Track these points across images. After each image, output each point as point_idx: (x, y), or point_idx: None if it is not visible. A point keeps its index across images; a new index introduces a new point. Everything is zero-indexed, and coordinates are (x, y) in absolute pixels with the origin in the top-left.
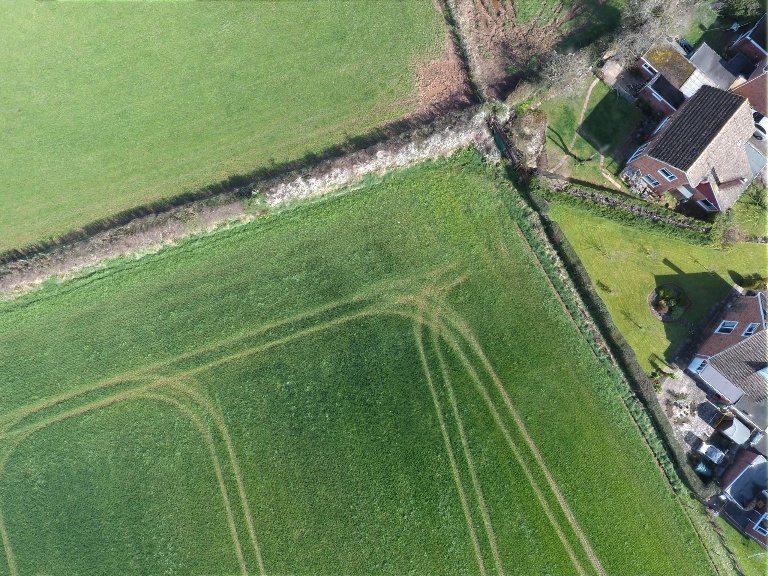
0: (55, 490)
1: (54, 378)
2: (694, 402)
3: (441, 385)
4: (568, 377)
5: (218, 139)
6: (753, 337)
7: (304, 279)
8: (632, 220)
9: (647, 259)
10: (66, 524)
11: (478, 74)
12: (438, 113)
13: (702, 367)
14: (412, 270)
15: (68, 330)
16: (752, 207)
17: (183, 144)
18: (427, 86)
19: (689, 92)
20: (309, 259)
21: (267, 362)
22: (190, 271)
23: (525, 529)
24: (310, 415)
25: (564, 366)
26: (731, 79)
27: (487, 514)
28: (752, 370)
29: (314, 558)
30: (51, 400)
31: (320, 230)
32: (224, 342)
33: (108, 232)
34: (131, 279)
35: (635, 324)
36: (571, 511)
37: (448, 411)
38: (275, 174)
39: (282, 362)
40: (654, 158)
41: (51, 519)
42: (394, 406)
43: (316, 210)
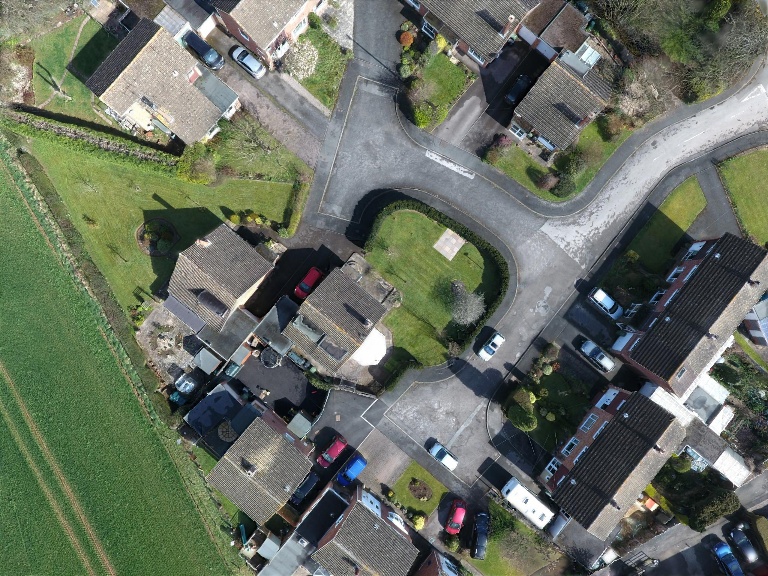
0: None
1: None
2: (180, 335)
3: None
4: (47, 309)
5: None
6: (177, 263)
7: None
8: (92, 152)
9: (136, 194)
10: None
11: None
12: None
13: None
14: None
15: None
16: (247, 144)
17: None
18: None
19: None
20: None
21: None
22: None
23: None
24: None
25: (43, 298)
26: (204, 16)
27: None
28: None
29: None
30: None
31: None
32: None
33: None
34: None
35: (120, 257)
36: (43, 440)
37: None
38: None
39: None
40: None
41: None
42: None
43: None
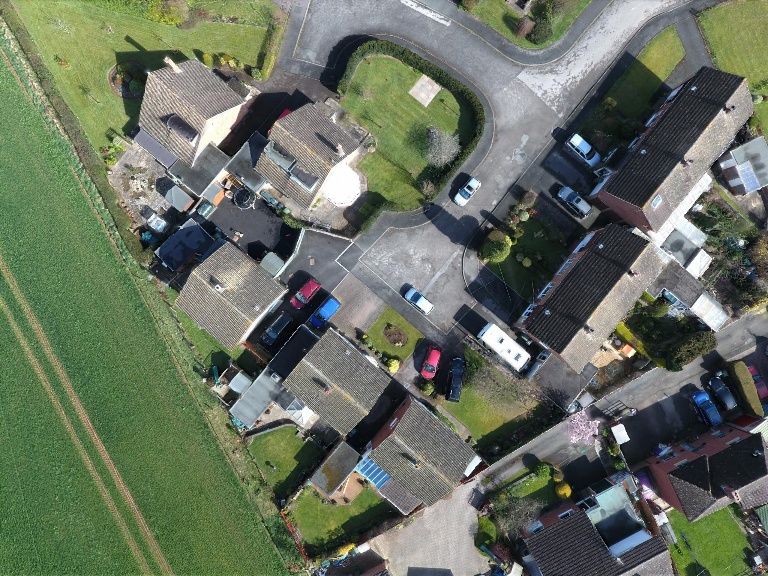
0: None
1: None
2: (152, 177)
3: None
4: (18, 148)
5: None
6: (147, 85)
7: None
8: None
9: (109, 36)
10: None
11: None
12: None
13: None
14: None
15: None
16: None
17: None
18: None
19: None
20: None
21: None
22: None
23: None
24: None
25: (15, 137)
26: None
27: None
28: None
29: None
30: None
31: None
32: None
33: None
34: None
35: (92, 99)
36: (14, 278)
37: None
38: None
39: None
40: None
41: None
42: None
43: None
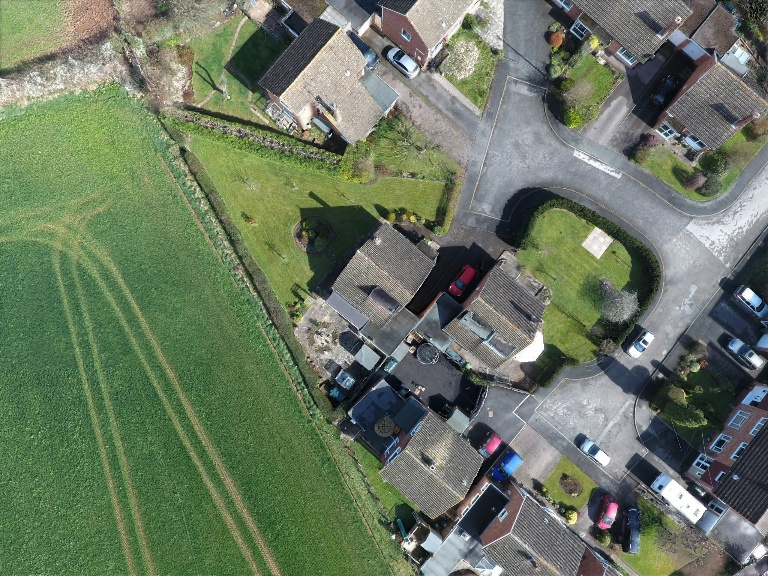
0: None
1: None
2: (336, 331)
3: (76, 310)
4: (208, 305)
5: None
6: (352, 260)
7: None
8: (258, 150)
9: (293, 192)
10: None
11: (127, 11)
12: None
13: None
14: (51, 198)
15: None
16: (400, 143)
17: None
18: (77, 22)
19: None
20: None
21: None
22: None
23: (156, 450)
24: None
25: (204, 294)
26: (365, 16)
27: (118, 435)
28: (365, 295)
29: None
30: None
31: None
32: None
33: None
34: None
35: (278, 255)
36: (205, 434)
37: (81, 335)
38: None
39: None
40: None
41: None
42: (26, 329)
43: None
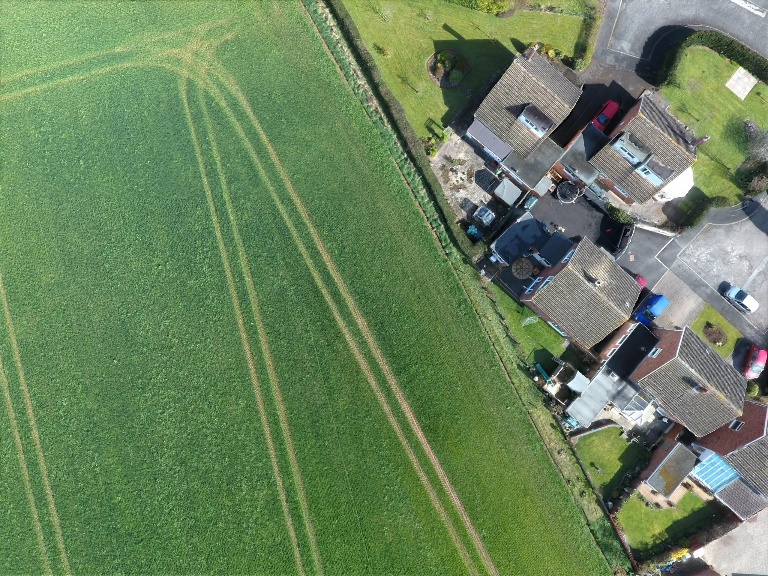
0: None
1: None
2: (471, 169)
3: (204, 138)
4: (339, 138)
5: None
6: (505, 74)
7: (64, 27)
8: None
9: (426, 24)
10: None
11: None
12: None
13: None
14: (177, 22)
15: None
16: None
17: None
18: None
19: None
20: (70, 7)
21: (22, 108)
22: None
23: (287, 286)
24: (64, 161)
25: (335, 126)
26: None
27: (248, 270)
28: (513, 118)
29: (62, 304)
30: None
31: None
32: None
33: None
34: None
35: (411, 88)
36: (338, 271)
37: (210, 164)
38: None
39: (37, 108)
40: None
41: None
42: (153, 156)
43: None
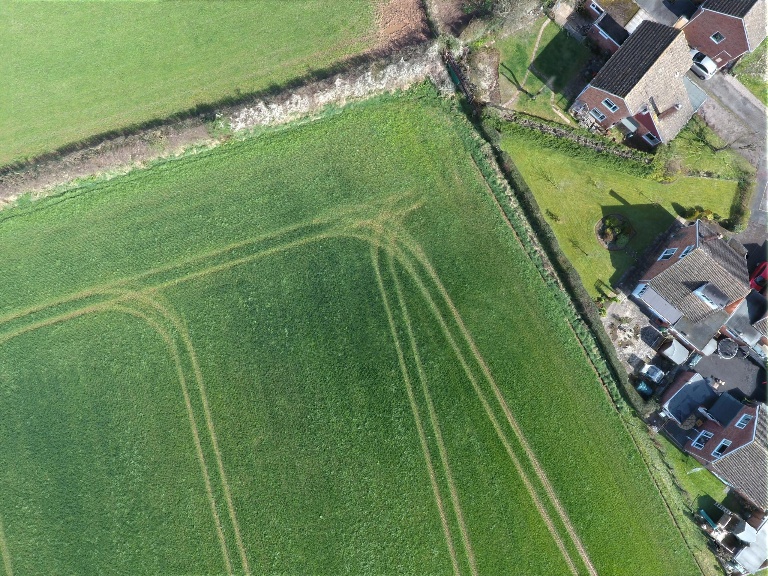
0: (26, 395)
1: (27, 290)
2: (637, 326)
3: (396, 304)
4: (517, 300)
5: (187, 69)
6: (687, 256)
7: (267, 202)
8: (577, 149)
9: (594, 190)
10: (36, 426)
11: (435, 13)
12: (397, 49)
13: (643, 290)
14: (370, 196)
15: (41, 245)
16: (695, 143)
17: (153, 73)
18: (387, 23)
19: (633, 30)
20: (272, 183)
21: (230, 279)
22: (158, 192)
23: (474, 442)
24: (270, 329)
25: (514, 289)
26: (674, 19)
27: (438, 427)
28: (688, 290)
29: (272, 464)
30: (24, 310)
31: (283, 156)
32: (189, 260)
33: (80, 152)
34: (102, 198)
35: (582, 251)
36: (518, 426)
37: (402, 329)
38: (241, 103)
39: (244, 279)
40: (596, 87)
41: (22, 421)
42: (350, 323)
43: (279, 137)
